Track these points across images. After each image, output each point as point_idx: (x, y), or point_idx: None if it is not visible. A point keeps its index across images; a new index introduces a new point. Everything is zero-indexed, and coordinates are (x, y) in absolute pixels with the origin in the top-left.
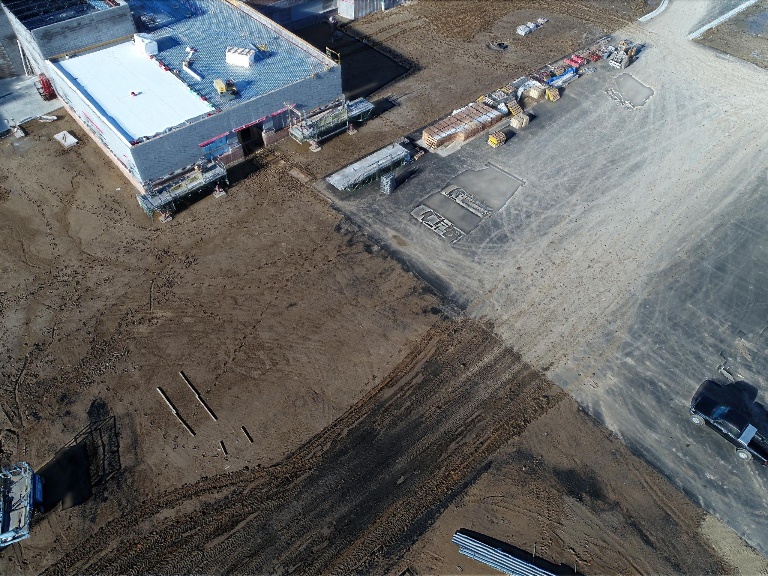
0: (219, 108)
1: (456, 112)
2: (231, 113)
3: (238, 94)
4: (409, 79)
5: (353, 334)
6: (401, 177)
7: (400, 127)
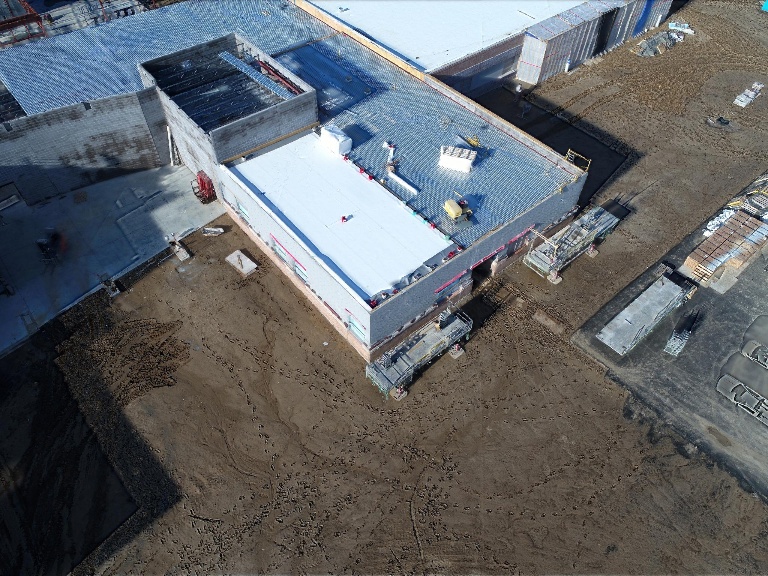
0: (457, 240)
1: (715, 225)
2: (475, 249)
3: (472, 217)
4: (631, 171)
5: None
6: (681, 327)
7: (648, 245)
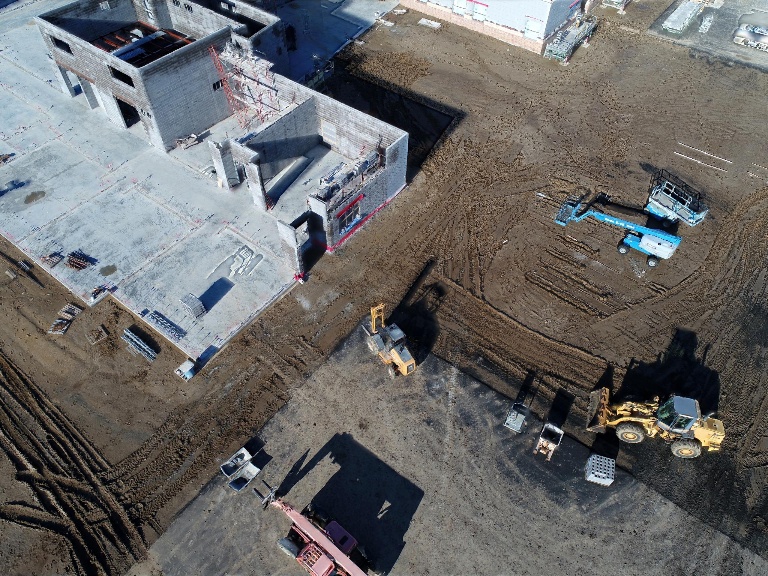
0: None
1: None
2: None
3: None
4: None
5: (767, 110)
6: None
7: None
